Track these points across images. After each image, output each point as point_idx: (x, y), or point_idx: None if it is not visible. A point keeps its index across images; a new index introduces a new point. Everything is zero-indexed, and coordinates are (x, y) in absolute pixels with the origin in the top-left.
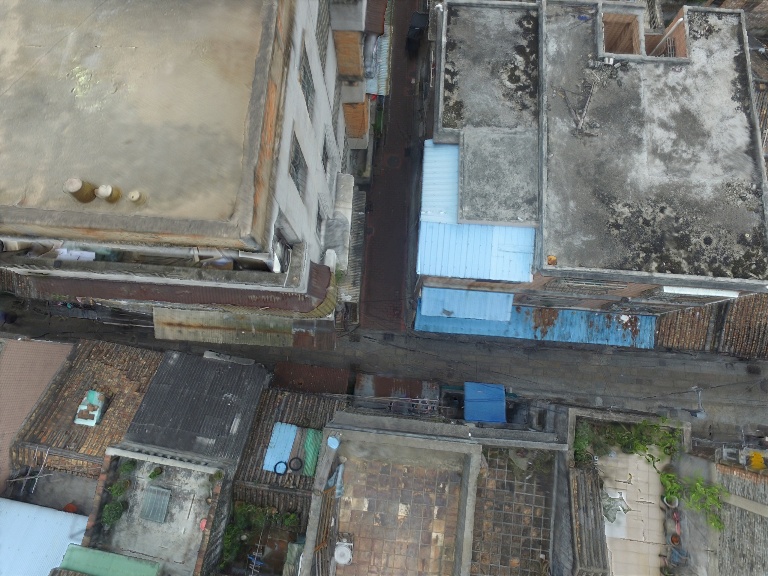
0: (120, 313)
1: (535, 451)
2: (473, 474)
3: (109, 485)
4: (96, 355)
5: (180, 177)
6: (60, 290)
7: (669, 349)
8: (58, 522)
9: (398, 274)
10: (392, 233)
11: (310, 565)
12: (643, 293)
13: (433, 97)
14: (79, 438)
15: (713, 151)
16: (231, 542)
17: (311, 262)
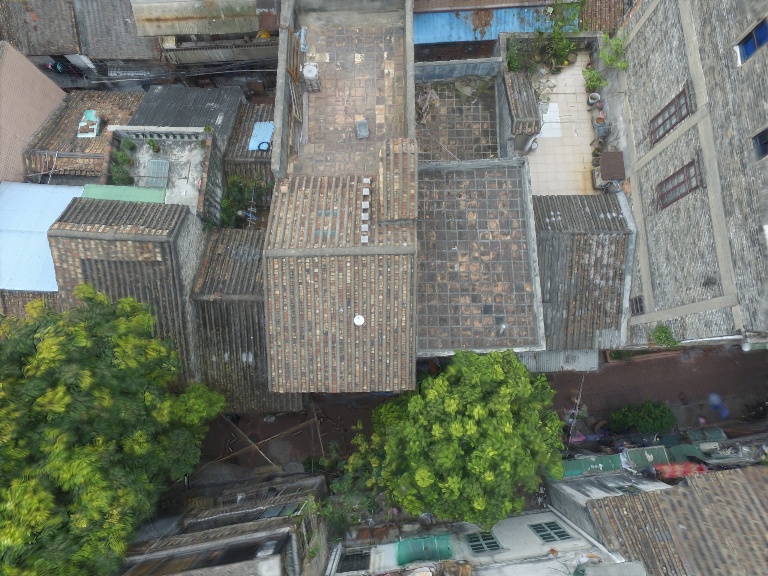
0: None
1: (477, 81)
2: None
3: (114, 160)
4: (89, 98)
5: None
6: None
7: None
8: (74, 193)
9: None
10: None
11: (284, 77)
12: None
13: None
14: (83, 145)
15: None
16: (229, 211)
17: None
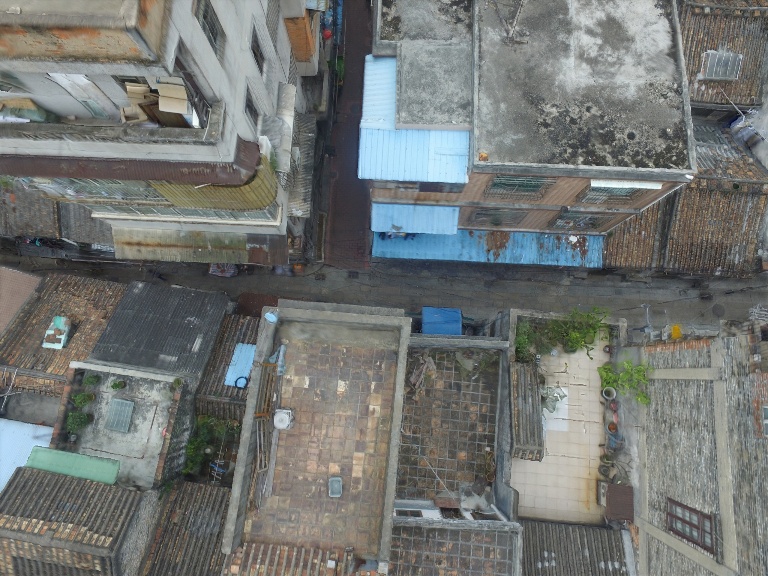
0: (88, 251)
1: (481, 353)
2: (403, 344)
3: None
4: (64, 287)
5: (85, 4)
6: (4, 170)
7: (623, 277)
8: (25, 433)
9: (362, 215)
10: (355, 176)
11: (250, 429)
12: (577, 196)
13: (372, 14)
14: (46, 360)
15: (637, 54)
16: (195, 453)
17: (239, 137)
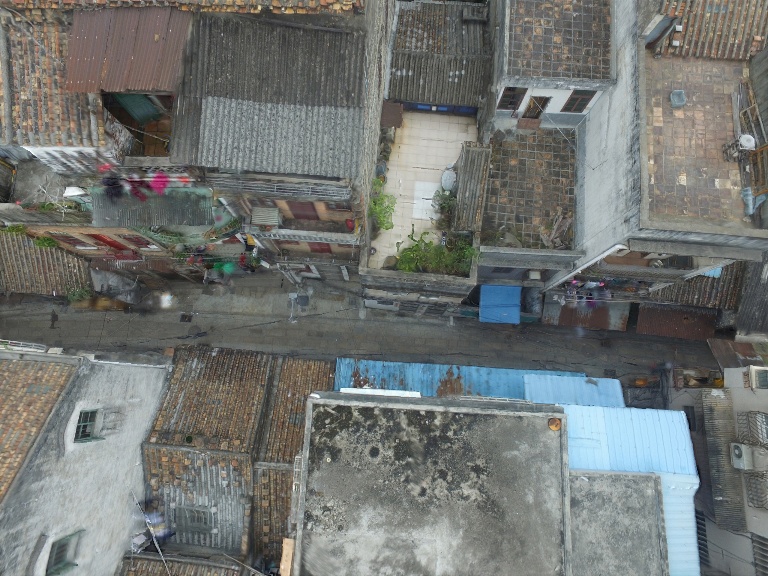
0: None
1: None
2: (646, 203)
3: None
4: None
5: None
6: None
7: None
8: None
9: None
10: None
11: None
12: None
13: None
14: None
15: None
16: None
17: None
